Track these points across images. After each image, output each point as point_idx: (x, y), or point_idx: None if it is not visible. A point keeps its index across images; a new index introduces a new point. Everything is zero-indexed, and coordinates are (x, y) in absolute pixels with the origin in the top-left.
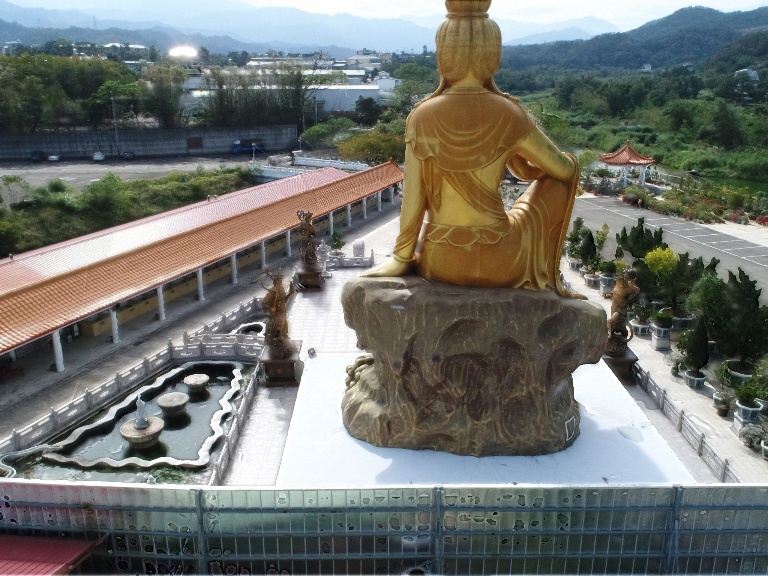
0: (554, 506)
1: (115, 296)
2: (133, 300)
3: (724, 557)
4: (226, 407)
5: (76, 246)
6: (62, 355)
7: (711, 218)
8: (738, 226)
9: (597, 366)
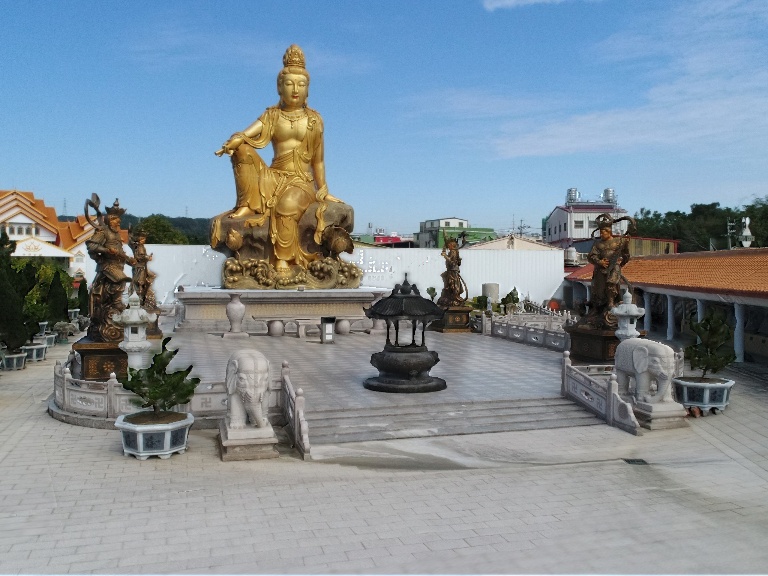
0: None
1: None
2: None
3: None
4: None
5: None
6: None
7: None
8: None
9: None
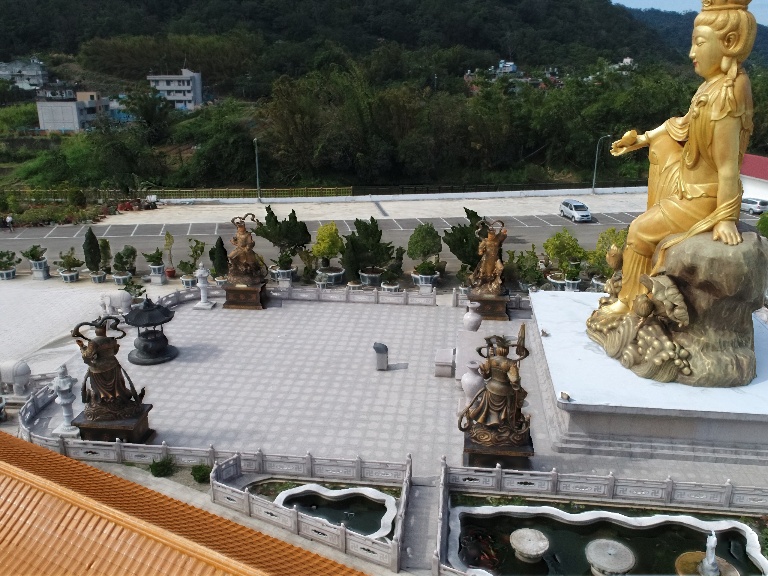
0: None
1: None
2: None
3: None
4: (601, 514)
5: None
6: None
7: (94, 216)
8: (122, 217)
9: (561, 293)
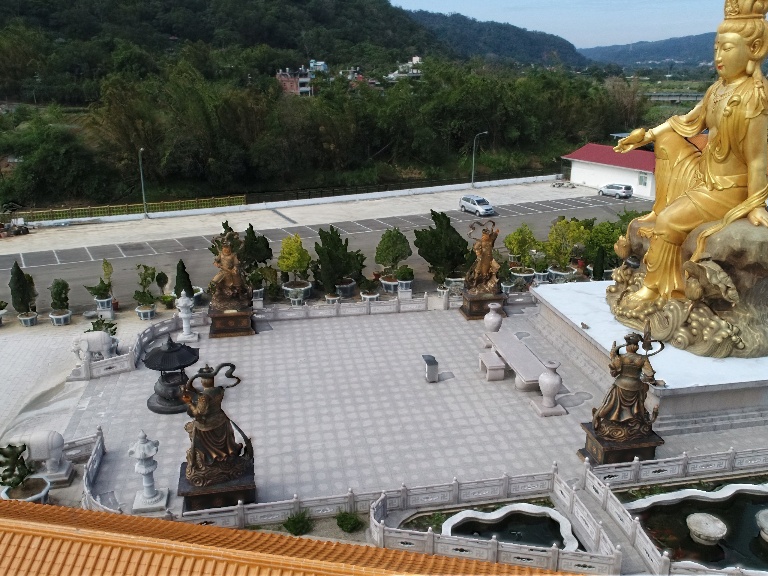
0: None
1: None
2: None
3: None
4: (736, 487)
5: None
6: None
7: None
8: None
9: (560, 286)
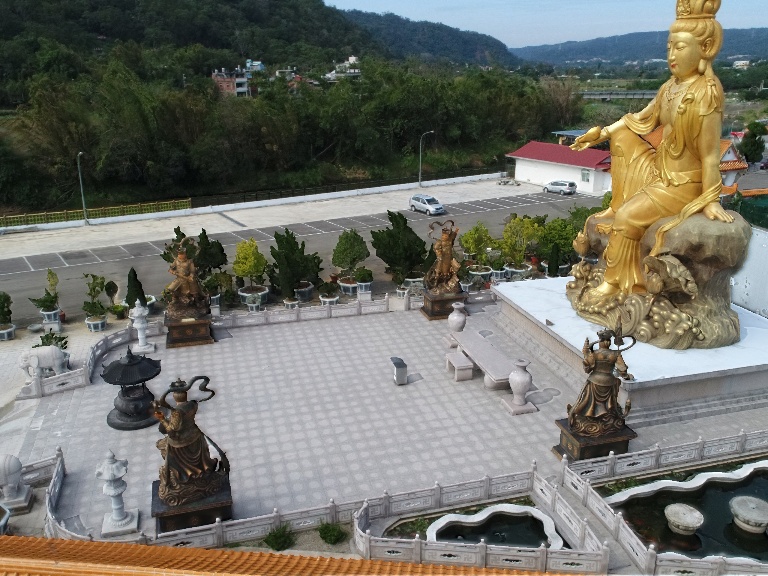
0: None
1: None
2: None
3: None
4: (706, 476)
5: None
6: None
7: None
8: None
9: (520, 283)
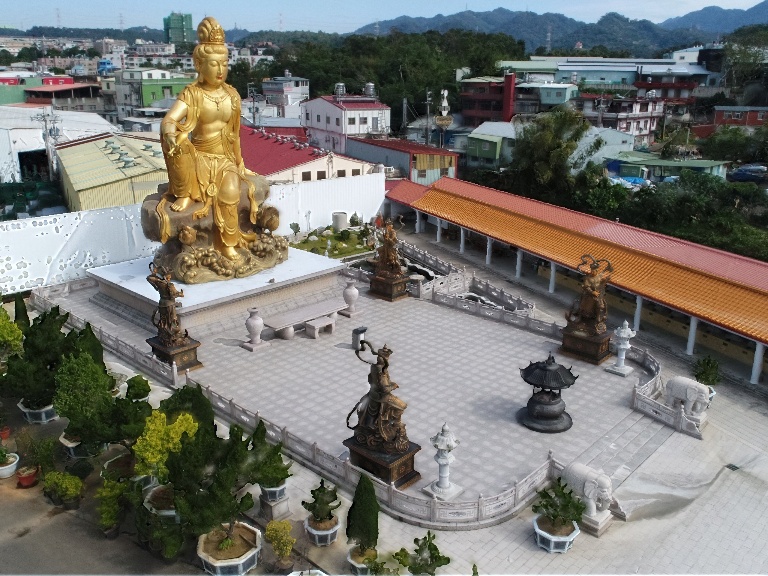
0: (135, 212)
1: (512, 239)
2: (582, 277)
3: (79, 241)
4: None
5: (646, 235)
6: (489, 254)
7: None
8: None
9: None
